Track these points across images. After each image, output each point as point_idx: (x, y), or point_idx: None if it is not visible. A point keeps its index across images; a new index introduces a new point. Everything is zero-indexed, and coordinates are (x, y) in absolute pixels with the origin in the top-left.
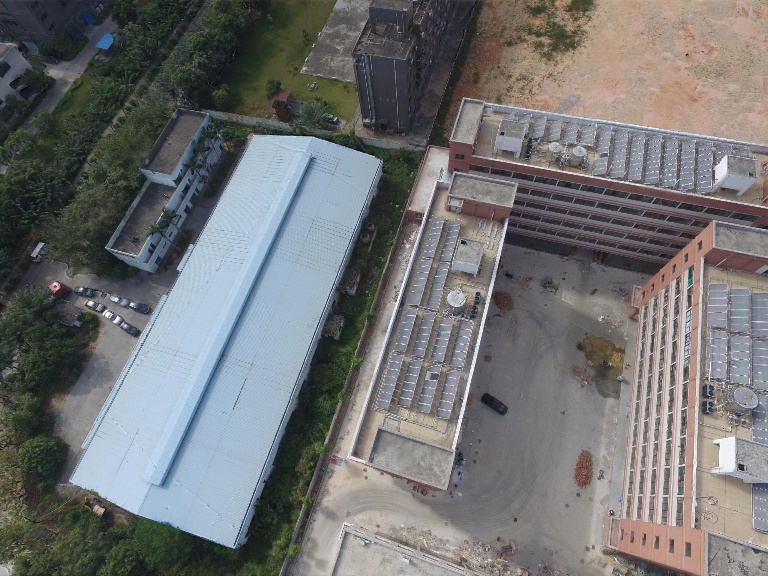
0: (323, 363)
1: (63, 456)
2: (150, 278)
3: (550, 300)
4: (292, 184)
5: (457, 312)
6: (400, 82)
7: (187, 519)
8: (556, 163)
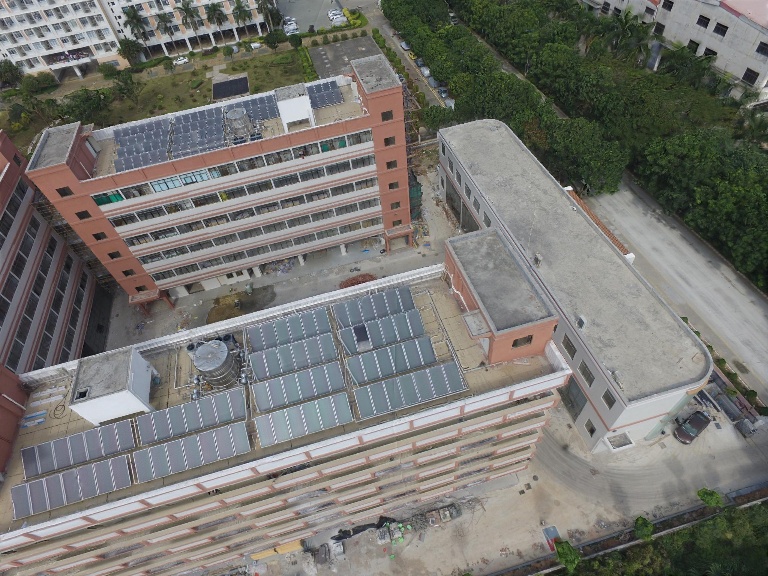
0: None
1: None
2: None
3: None
4: None
5: None
6: None
7: None
8: None
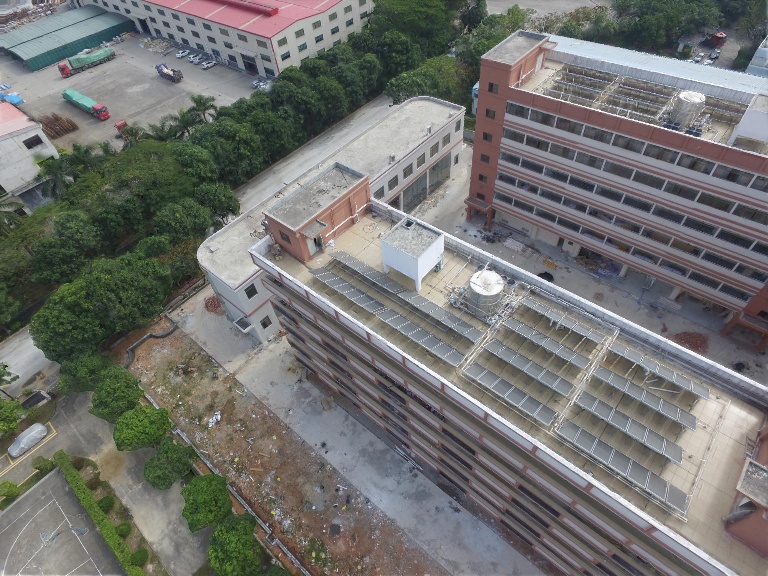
0: None
1: None
2: None
3: None
4: None
5: None
6: None
7: None
8: None
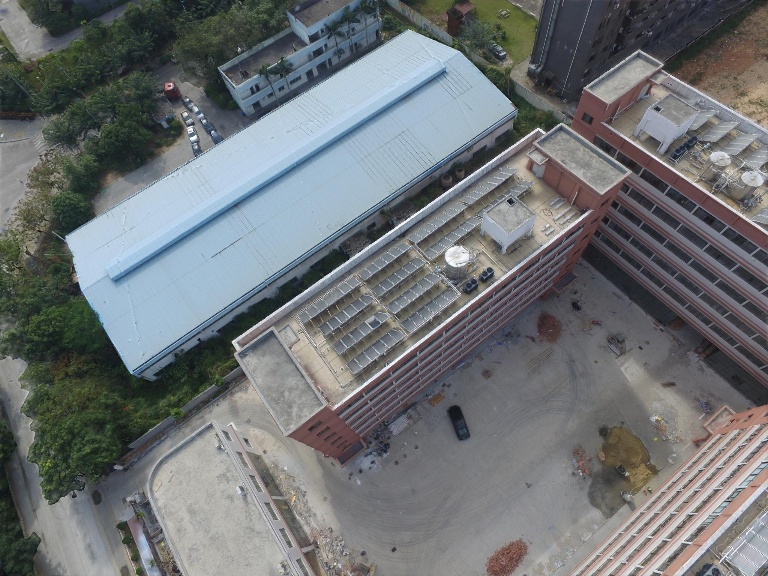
0: (325, 274)
1: (87, 221)
2: (242, 119)
3: (606, 360)
4: (406, 86)
5: (452, 275)
6: (589, 27)
7: (114, 322)
8: (710, 183)
